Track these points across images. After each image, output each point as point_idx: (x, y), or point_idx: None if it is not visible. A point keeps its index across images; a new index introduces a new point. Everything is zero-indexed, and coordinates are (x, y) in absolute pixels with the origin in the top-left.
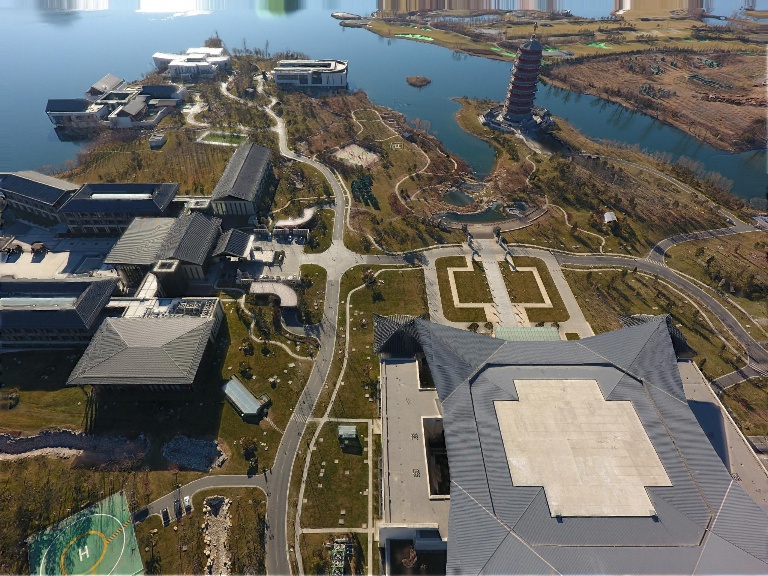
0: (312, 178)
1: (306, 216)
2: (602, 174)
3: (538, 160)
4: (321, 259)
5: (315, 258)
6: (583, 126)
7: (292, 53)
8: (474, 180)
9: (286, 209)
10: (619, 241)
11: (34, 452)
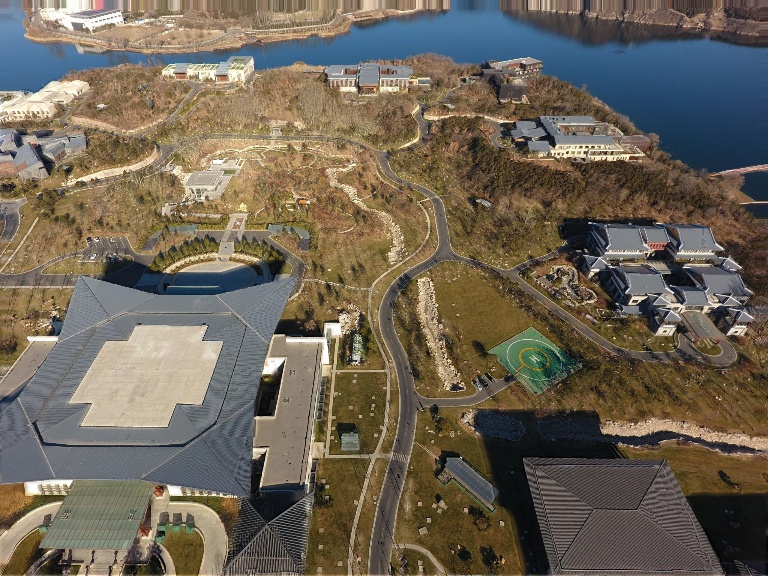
0: None
1: None
2: None
3: None
4: None
5: None
6: None
7: None
8: None
9: None
10: None
11: (646, 429)
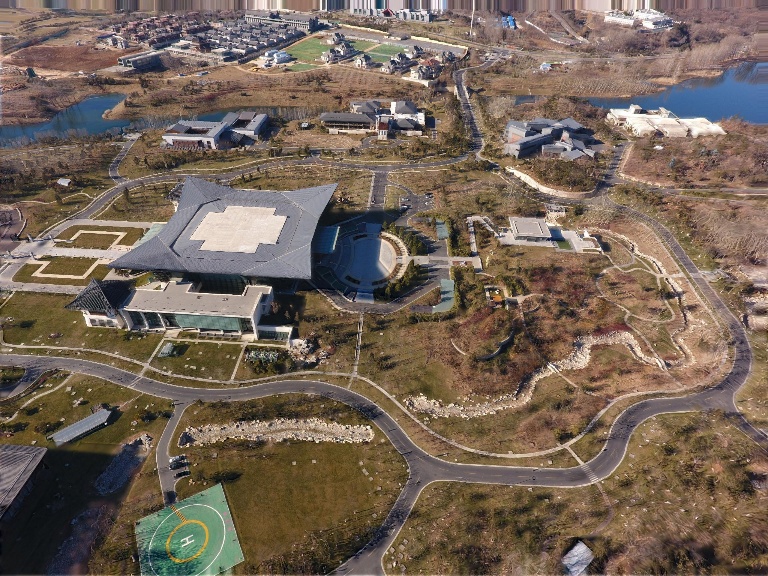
0: None
1: None
2: (8, 169)
3: None
4: None
5: None
6: None
7: None
8: None
9: None
10: (92, 187)
11: None
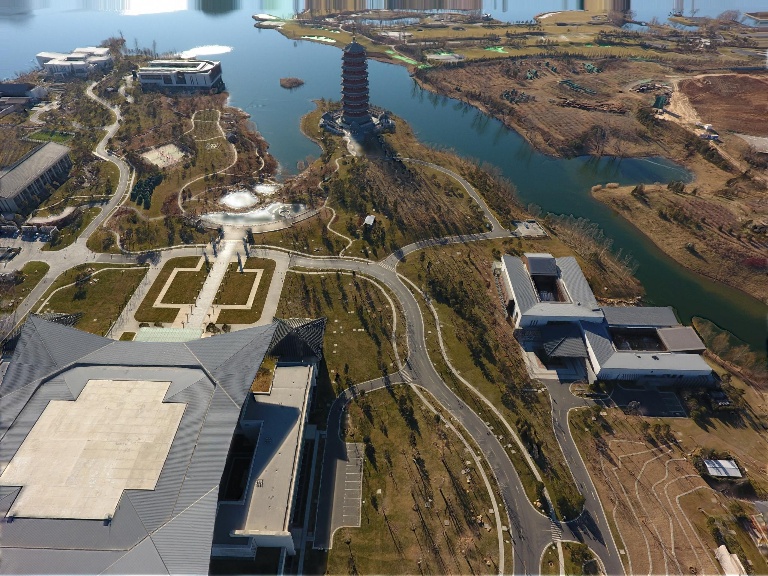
0: (104, 177)
1: (63, 214)
2: None
3: (345, 162)
4: (53, 257)
5: (47, 256)
6: (424, 129)
7: (179, 53)
8: (273, 181)
9: (54, 207)
10: (363, 244)
11: None
